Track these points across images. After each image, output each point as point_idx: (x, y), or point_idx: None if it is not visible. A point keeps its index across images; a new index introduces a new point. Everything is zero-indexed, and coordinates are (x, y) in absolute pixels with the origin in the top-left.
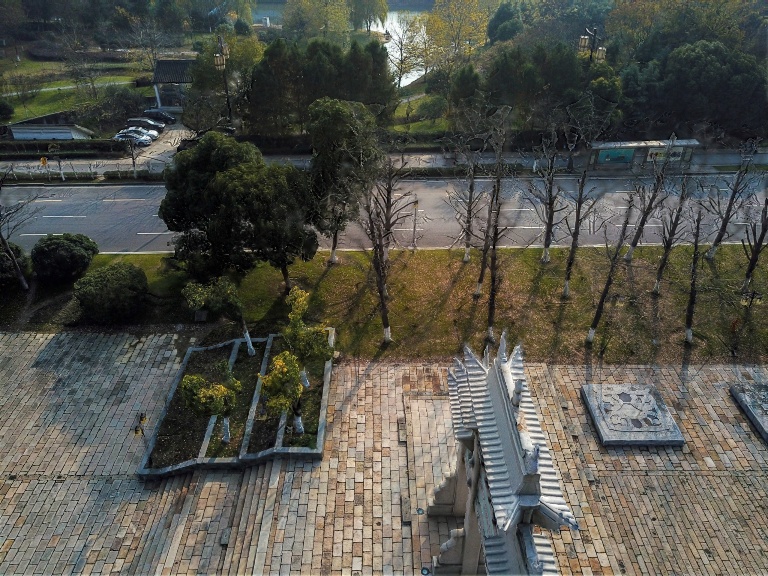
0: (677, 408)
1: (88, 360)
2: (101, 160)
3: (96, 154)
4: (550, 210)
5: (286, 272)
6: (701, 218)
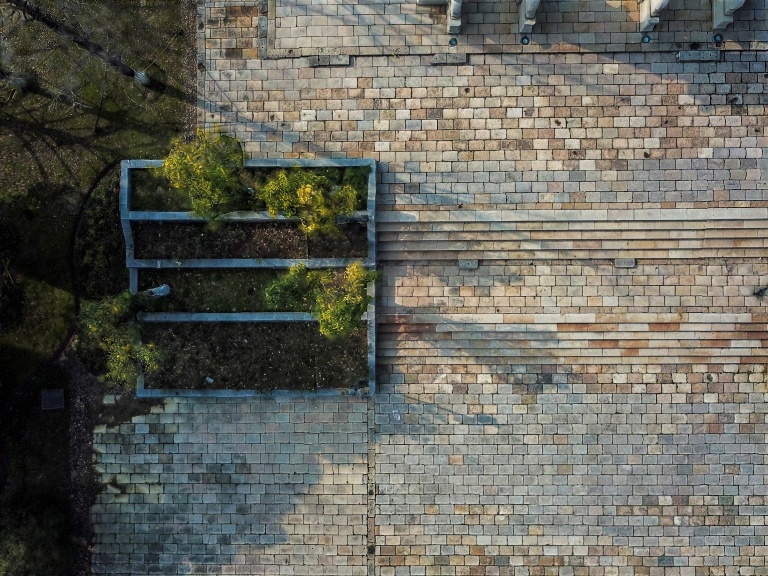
0: None
1: (156, 546)
2: None
3: None
4: None
5: None
6: None
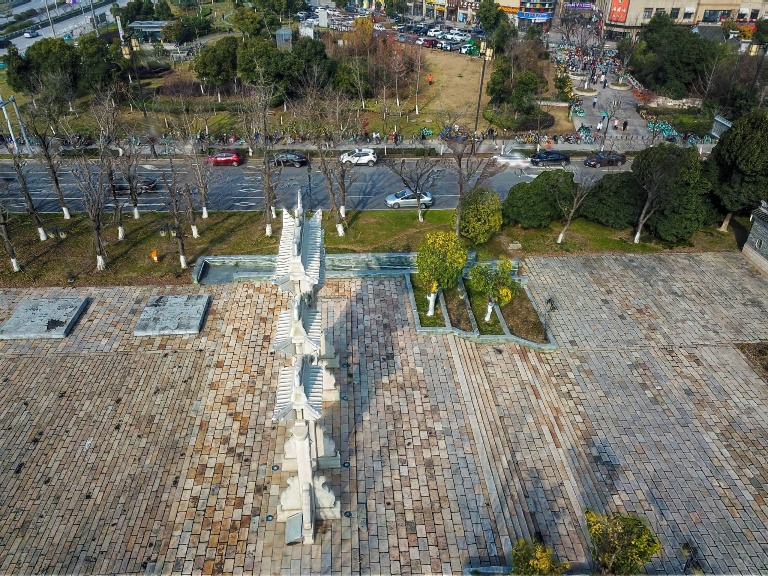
0: None
1: None
2: None
3: None
4: None
5: None
6: None
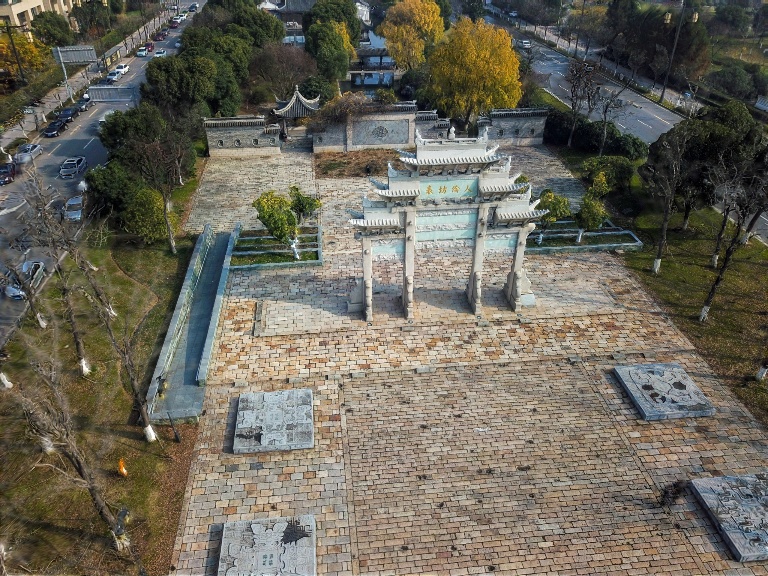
0: (698, 428)
1: (561, 190)
2: None
3: None
4: None
5: (687, 215)
6: None
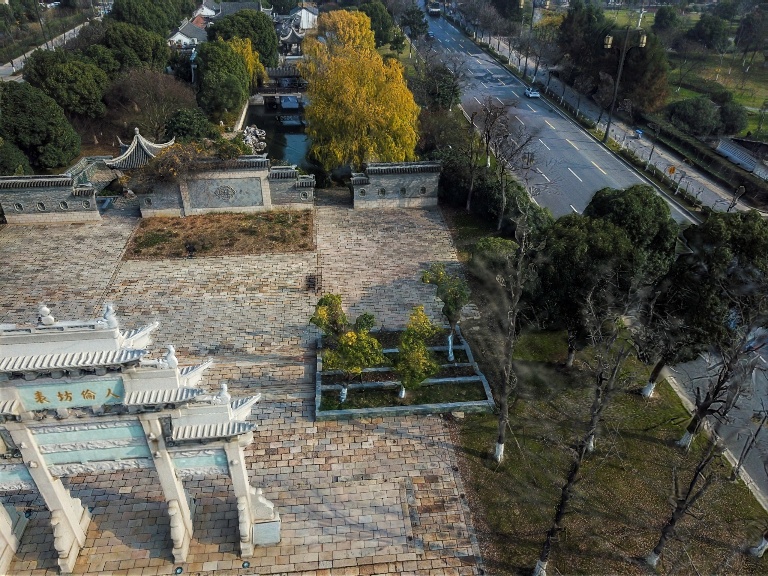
0: None
1: None
2: None
3: None
4: None
5: None
6: None
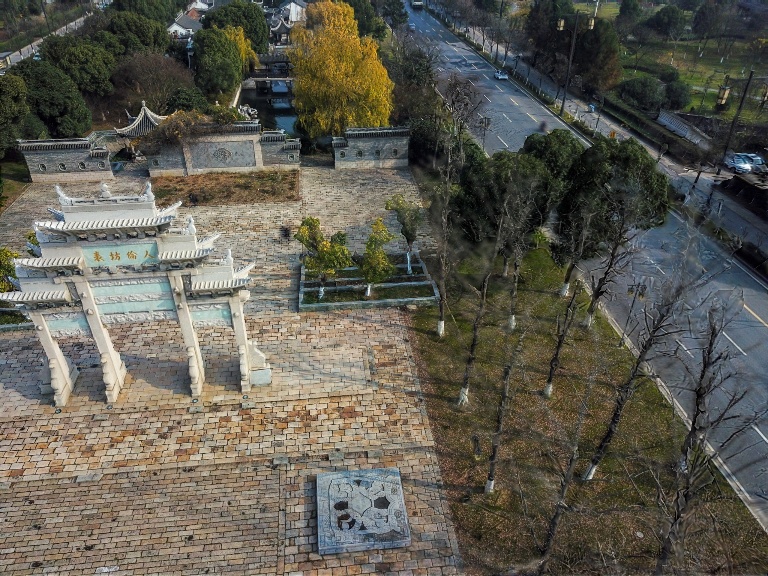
0: (380, 566)
1: None
2: (666, 159)
3: (671, 153)
4: (697, 403)
5: (506, 261)
6: (574, 456)
